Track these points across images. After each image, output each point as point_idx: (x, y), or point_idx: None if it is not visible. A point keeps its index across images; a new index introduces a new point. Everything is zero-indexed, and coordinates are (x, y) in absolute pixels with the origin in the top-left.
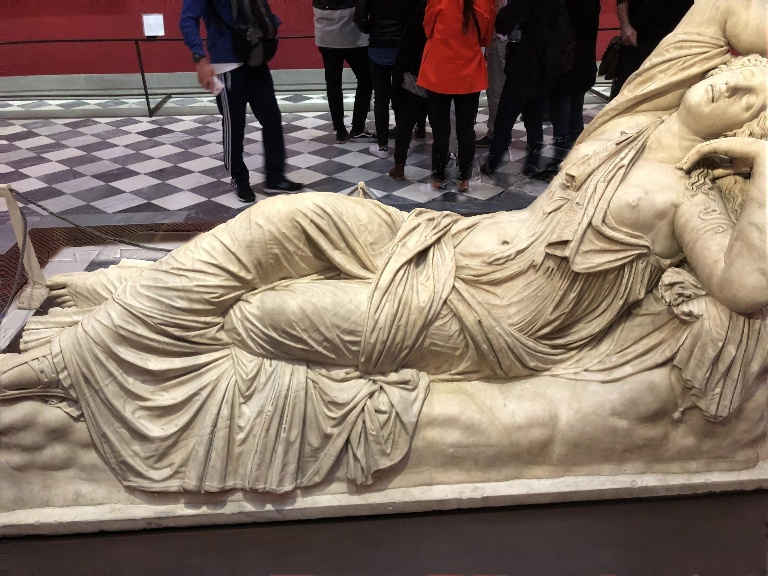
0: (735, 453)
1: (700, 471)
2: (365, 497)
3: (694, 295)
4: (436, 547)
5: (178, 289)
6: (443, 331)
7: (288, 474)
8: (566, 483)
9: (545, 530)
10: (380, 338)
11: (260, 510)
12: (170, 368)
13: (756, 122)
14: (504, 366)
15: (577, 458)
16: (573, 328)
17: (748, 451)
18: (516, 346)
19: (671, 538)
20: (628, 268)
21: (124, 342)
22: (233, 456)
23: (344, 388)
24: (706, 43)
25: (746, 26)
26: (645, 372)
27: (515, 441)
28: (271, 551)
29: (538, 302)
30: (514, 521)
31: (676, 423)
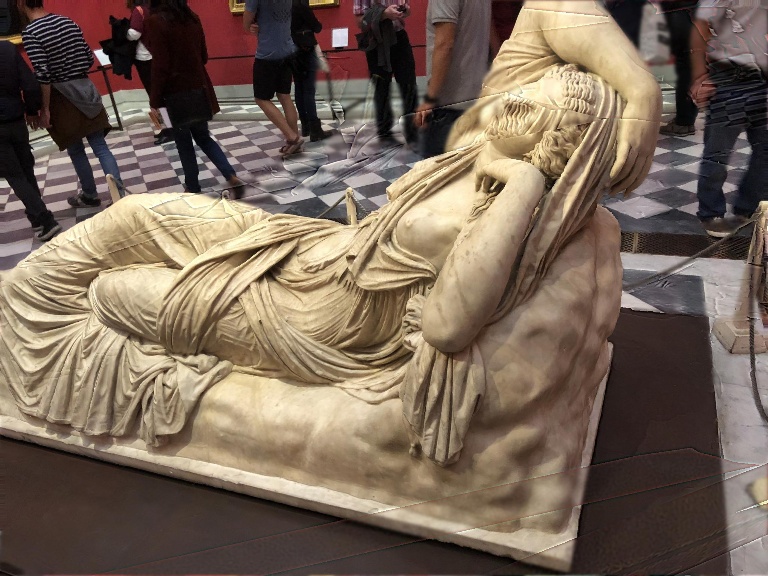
0: None
1: None
2: (156, 457)
3: None
4: (187, 515)
5: None
6: (232, 326)
7: (97, 422)
8: (314, 492)
9: (279, 530)
10: (167, 322)
11: (85, 447)
12: (41, 321)
13: (540, 143)
14: (292, 369)
15: (326, 471)
16: (383, 346)
17: None
18: (298, 351)
19: (383, 575)
20: (414, 291)
21: (18, 296)
22: (72, 399)
23: (147, 360)
24: None
25: None
26: (392, 399)
27: (272, 439)
28: (82, 481)
29: (336, 313)
30: (263, 514)
31: (416, 459)
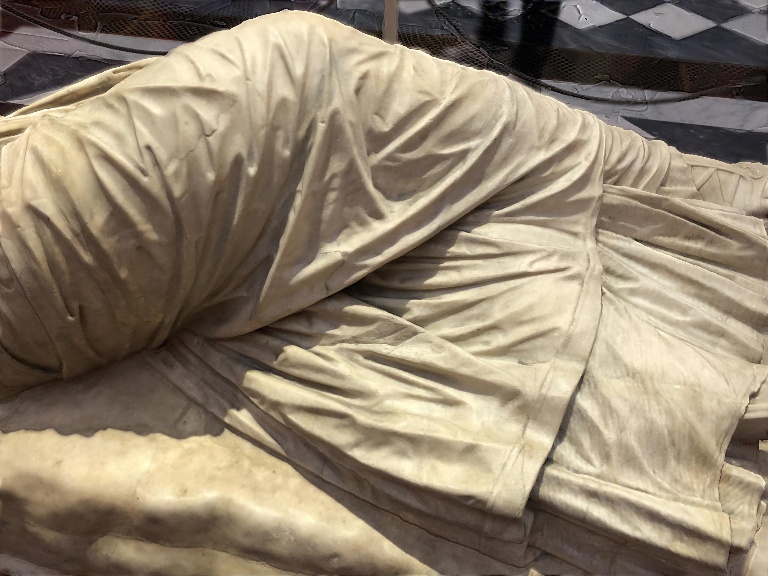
0: None
1: None
2: None
3: None
4: None
5: None
6: None
7: None
8: None
9: None
10: None
11: None
12: None
13: None
14: None
15: None
16: None
17: None
18: None
19: None
20: None
21: None
22: None
23: None
24: None
25: None
26: None
27: None
28: None
29: None
30: None
31: None
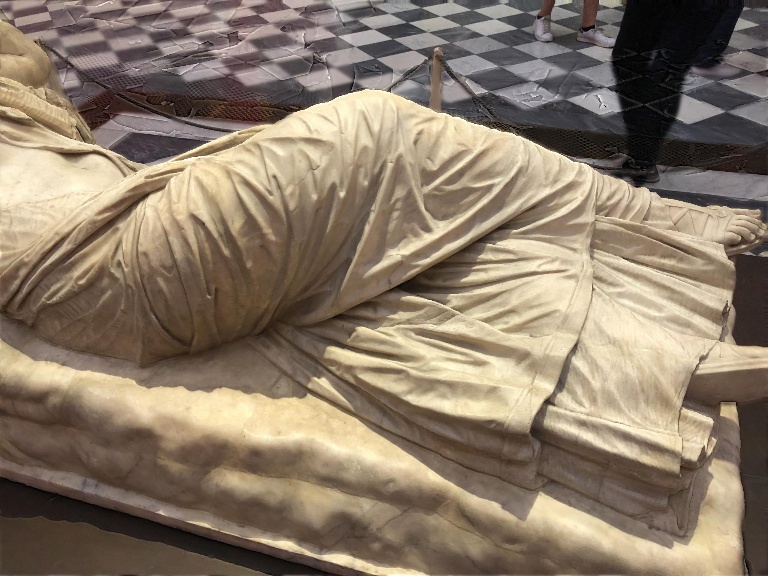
0: None
1: None
2: None
3: None
4: None
5: None
6: None
7: None
8: None
9: None
10: None
11: None
12: None
13: None
14: None
15: None
16: None
17: None
18: None
19: None
20: None
21: None
22: None
23: None
24: None
25: None
26: None
27: None
28: None
29: None
30: None
31: None
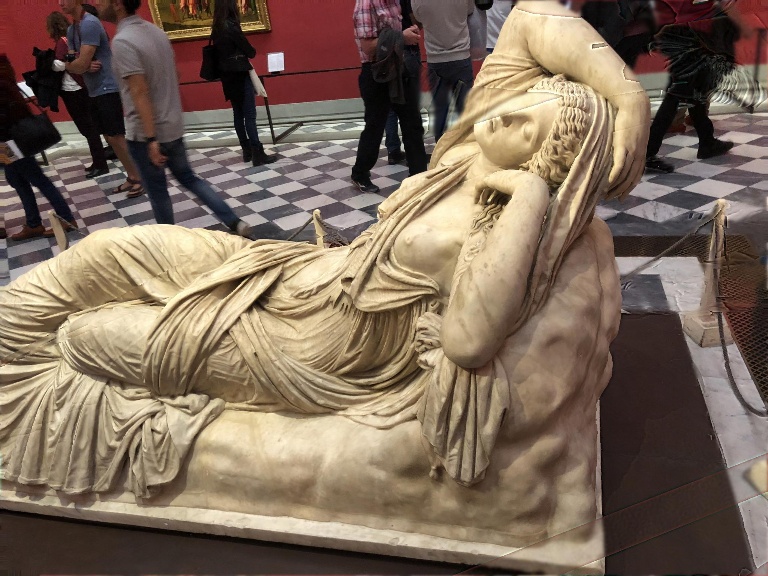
0: (509, 526)
1: (472, 540)
2: (148, 510)
3: (438, 343)
4: (190, 568)
5: (11, 307)
6: (224, 361)
7: (78, 478)
8: (328, 528)
9: (294, 572)
10: (153, 362)
11: (64, 506)
12: (4, 373)
13: (539, 152)
14: (291, 401)
15: (340, 504)
16: (384, 369)
17: (526, 527)
18: (297, 382)
19: None
20: (417, 309)
21: None
22: (46, 455)
23: (131, 406)
24: (510, 65)
25: (543, 44)
26: (406, 422)
27: (278, 477)
28: (63, 544)
29: (333, 339)
30: (273, 558)
31: (437, 482)
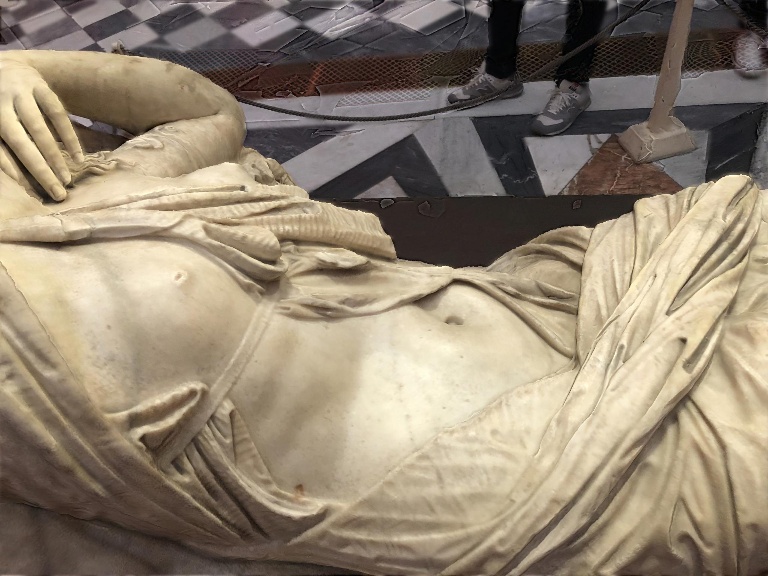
0: None
1: None
2: None
3: None
4: None
5: None
6: None
7: None
8: None
9: None
10: None
11: None
12: None
13: None
14: None
15: None
16: None
17: None
18: None
19: None
20: None
21: None
22: None
23: None
24: None
25: None
26: None
27: None
28: None
29: None
30: None
31: None
